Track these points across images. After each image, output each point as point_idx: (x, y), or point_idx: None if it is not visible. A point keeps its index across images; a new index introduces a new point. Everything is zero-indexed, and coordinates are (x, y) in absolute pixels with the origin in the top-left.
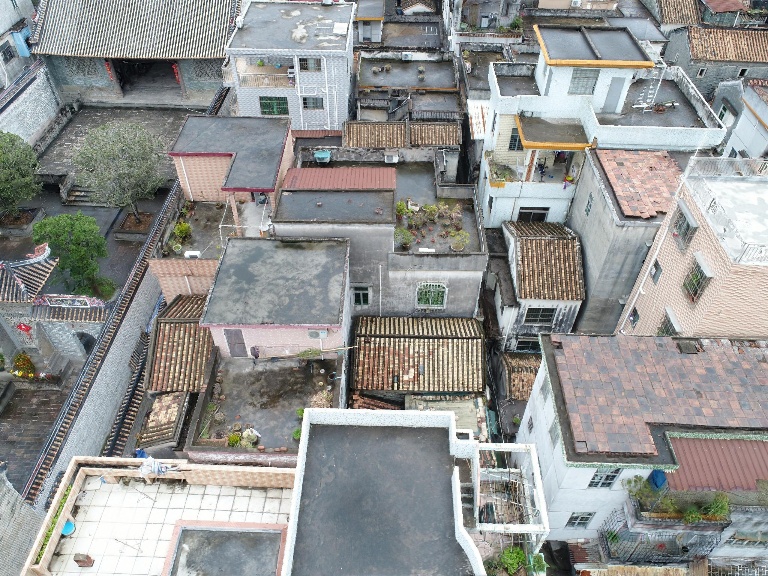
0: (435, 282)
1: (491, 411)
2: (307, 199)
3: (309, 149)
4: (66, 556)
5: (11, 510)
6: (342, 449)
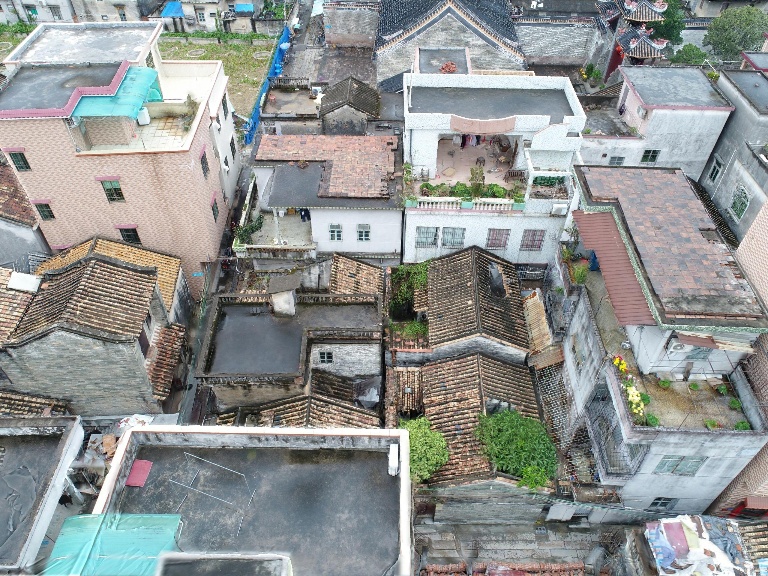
0: (748, 191)
1: None
2: (759, 81)
3: None
4: None
5: None
6: (552, 98)
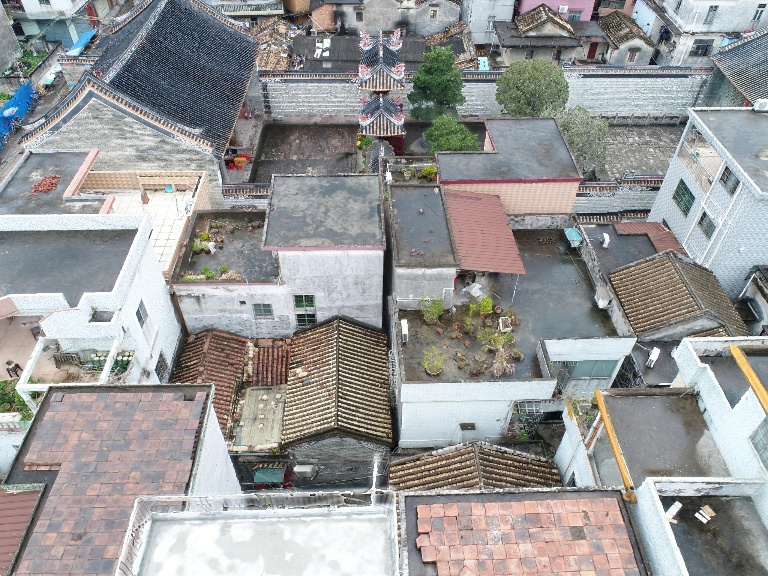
0: None
1: (283, 476)
2: (429, 203)
3: (577, 222)
4: (154, 194)
5: (209, 180)
6: (120, 246)
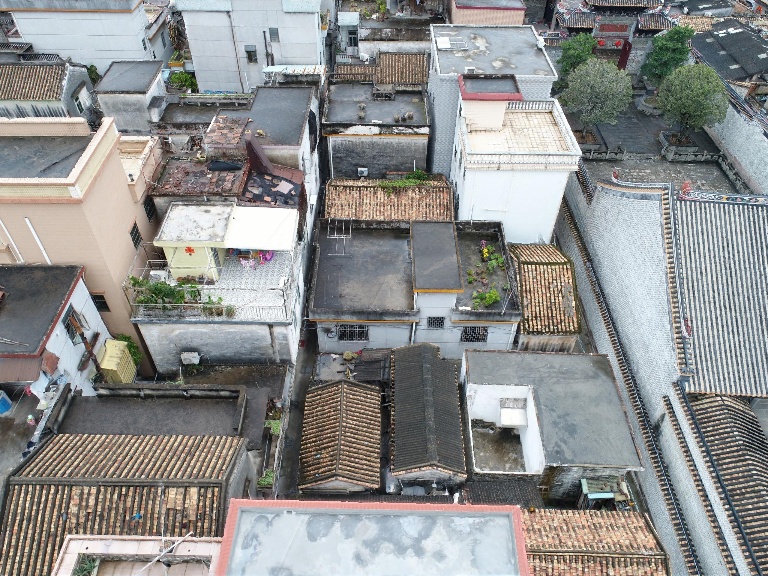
0: None
1: None
2: None
3: None
4: None
5: None
6: None
